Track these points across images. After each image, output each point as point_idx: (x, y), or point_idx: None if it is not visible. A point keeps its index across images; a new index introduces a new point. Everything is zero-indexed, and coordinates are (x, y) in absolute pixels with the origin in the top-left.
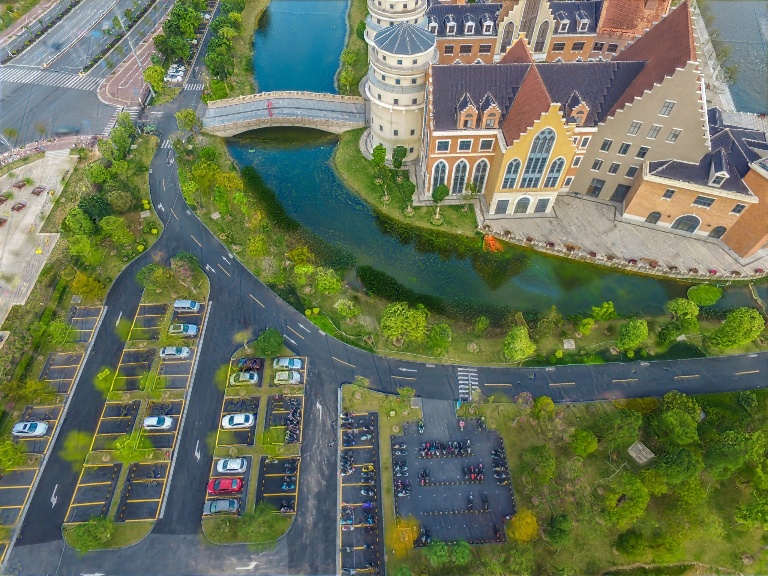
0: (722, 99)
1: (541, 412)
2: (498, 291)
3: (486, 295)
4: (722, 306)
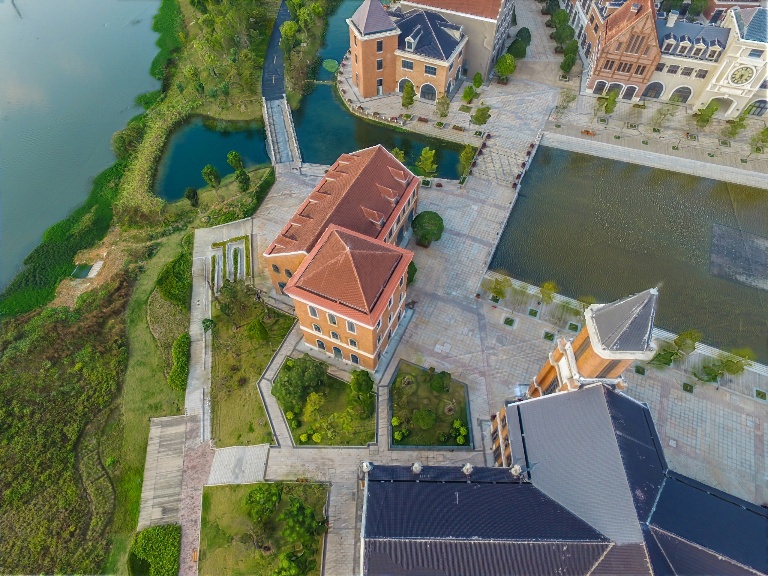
0: (565, 136)
1: (277, 1)
2: (350, 5)
3: (348, 2)
4: (320, 68)
